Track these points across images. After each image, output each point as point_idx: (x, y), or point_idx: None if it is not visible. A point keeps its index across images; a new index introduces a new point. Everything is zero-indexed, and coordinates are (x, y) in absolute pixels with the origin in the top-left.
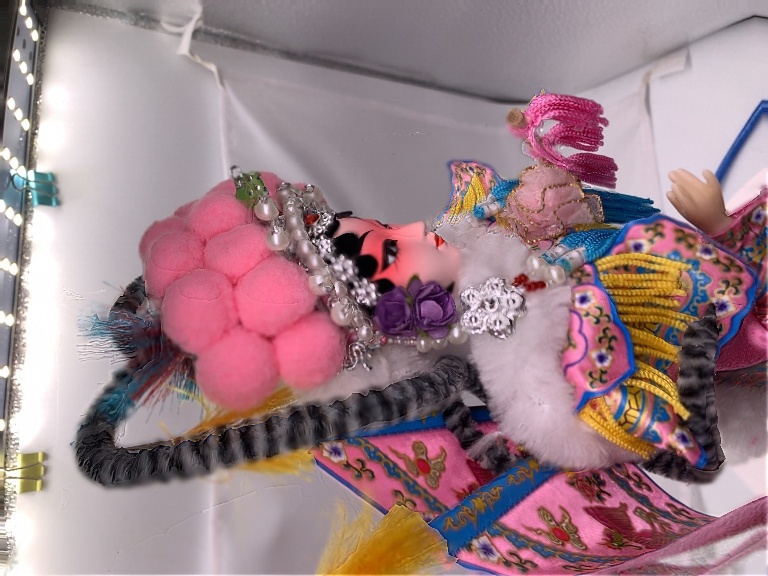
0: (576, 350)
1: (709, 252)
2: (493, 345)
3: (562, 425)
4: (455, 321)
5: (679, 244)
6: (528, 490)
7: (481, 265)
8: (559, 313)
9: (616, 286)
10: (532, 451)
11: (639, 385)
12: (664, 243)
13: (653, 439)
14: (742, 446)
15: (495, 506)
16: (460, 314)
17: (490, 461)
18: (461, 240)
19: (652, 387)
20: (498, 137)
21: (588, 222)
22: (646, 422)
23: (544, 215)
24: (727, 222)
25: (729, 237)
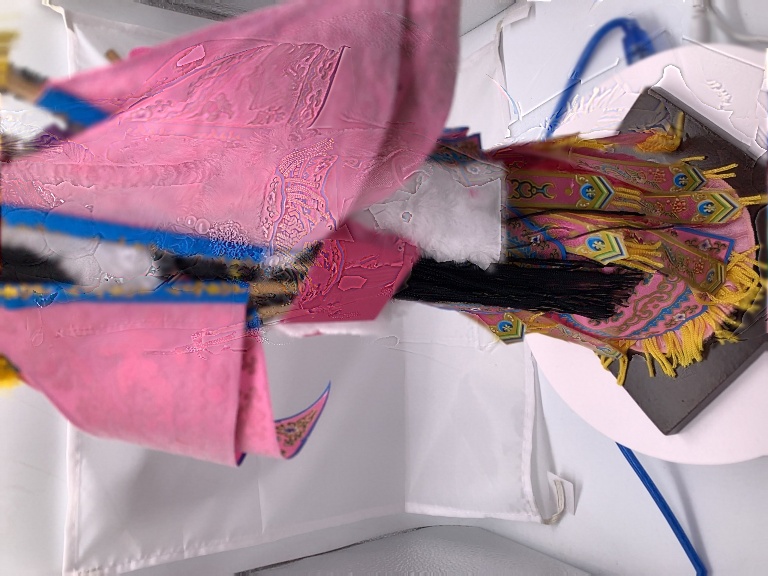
0: None
1: None
2: None
3: None
4: None
5: None
6: None
7: None
8: None
9: None
10: None
11: None
12: None
13: None
14: None
15: None
16: None
17: None
18: None
19: None
20: None
21: None
22: None
23: None
24: None
25: None
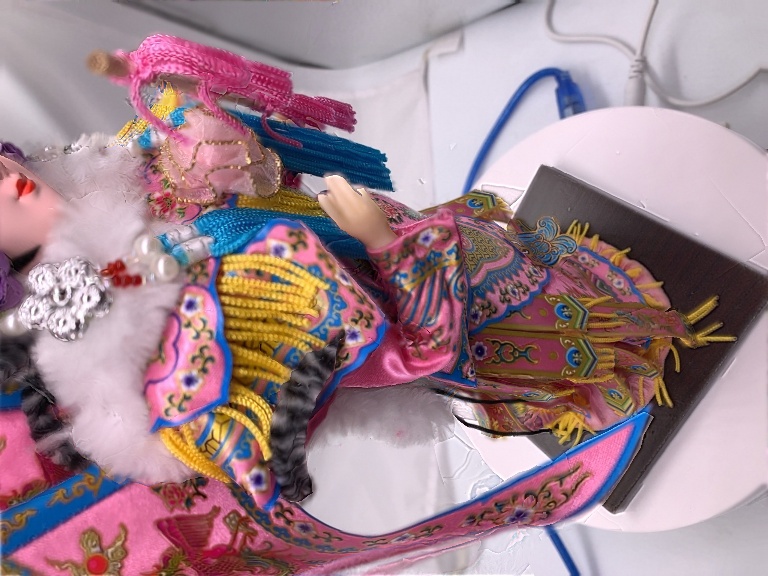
0: (163, 366)
1: (346, 279)
2: (56, 346)
3: (127, 448)
4: (14, 305)
5: (320, 260)
6: (82, 506)
7: (67, 237)
8: (153, 318)
9: (238, 293)
10: (98, 464)
11: (229, 414)
12: (306, 253)
13: (229, 474)
14: (386, 437)
15: (9, 540)
16: (24, 297)
17: (63, 457)
18: (98, 175)
19: (243, 418)
20: (265, 16)
21: (250, 194)
22: (224, 456)
23: (194, 175)
24: (387, 240)
25: (385, 258)
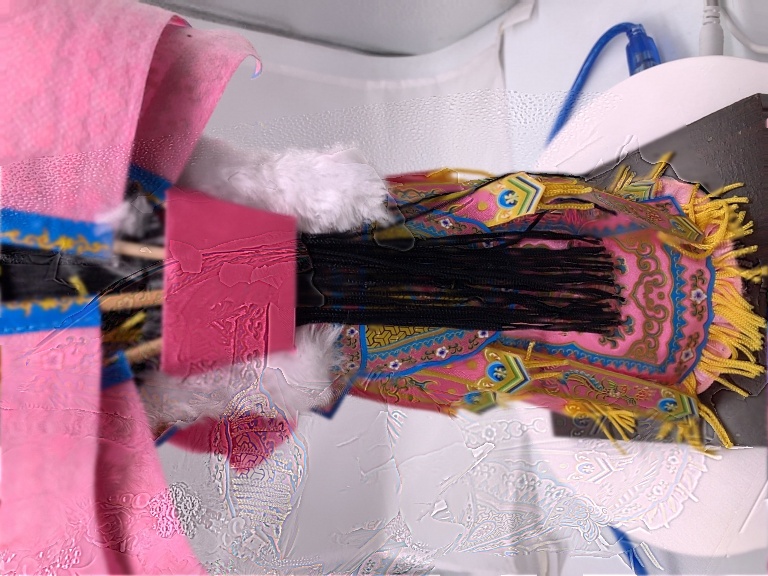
0: None
1: None
2: None
3: None
4: None
5: None
6: None
7: None
8: None
9: None
10: None
11: None
12: None
13: None
14: None
15: None
16: None
17: None
18: None
19: None
20: None
21: None
22: None
23: None
24: None
25: None
